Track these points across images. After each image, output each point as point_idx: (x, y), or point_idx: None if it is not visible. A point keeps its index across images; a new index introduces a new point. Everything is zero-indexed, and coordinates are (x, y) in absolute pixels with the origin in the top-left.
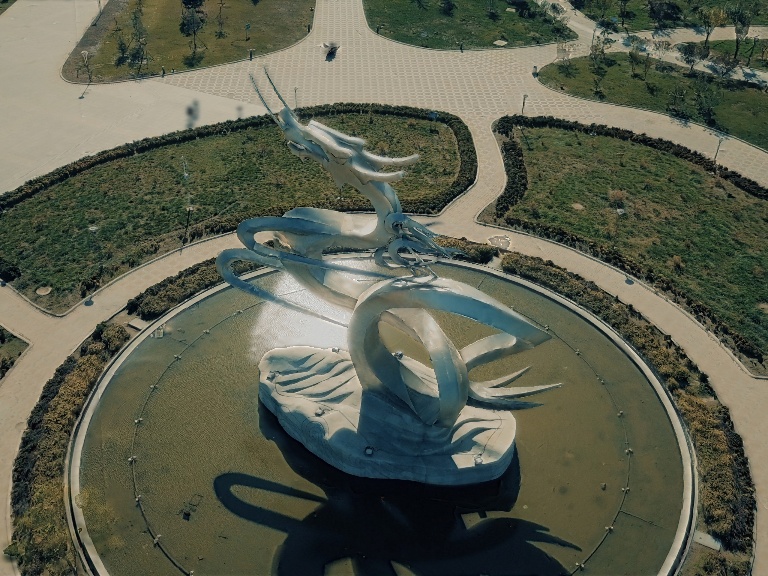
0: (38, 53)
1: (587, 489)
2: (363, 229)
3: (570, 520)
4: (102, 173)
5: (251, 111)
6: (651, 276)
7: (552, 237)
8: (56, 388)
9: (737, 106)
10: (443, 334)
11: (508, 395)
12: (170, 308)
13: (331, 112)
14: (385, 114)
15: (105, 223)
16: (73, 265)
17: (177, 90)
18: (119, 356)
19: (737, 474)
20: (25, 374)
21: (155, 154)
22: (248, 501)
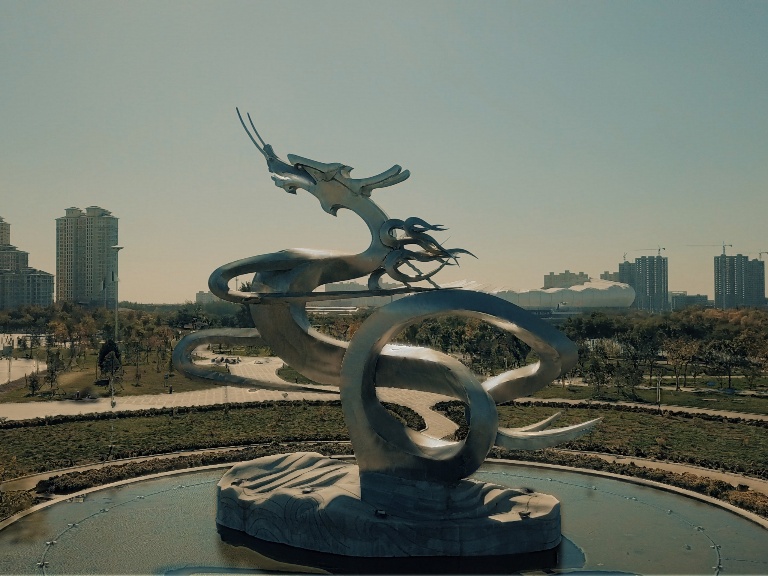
0: None
1: (668, 551)
2: (354, 254)
3: (663, 568)
4: (7, 433)
5: None
6: (641, 452)
7: None
8: None
9: None
10: None
11: (542, 435)
12: (92, 487)
13: (261, 406)
14: (318, 406)
15: (8, 454)
16: None
17: (93, 403)
18: (24, 510)
19: None
20: None
21: (70, 425)
22: None
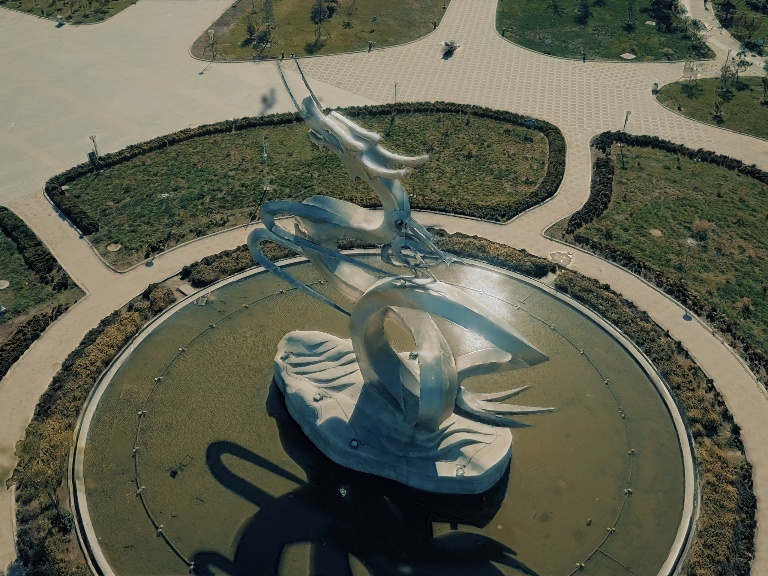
0: (176, 29)
1: (570, 521)
2: (372, 224)
3: (542, 549)
4: (198, 145)
5: (353, 101)
6: (712, 315)
7: (618, 260)
8: (96, 337)
9: None
10: (440, 339)
11: (499, 411)
12: (219, 279)
13: (430, 110)
14: (484, 117)
15: (186, 192)
16: (146, 227)
17: (290, 74)
18: (160, 317)
19: (739, 536)
20: (75, 320)
21: (251, 133)
22: (233, 470)
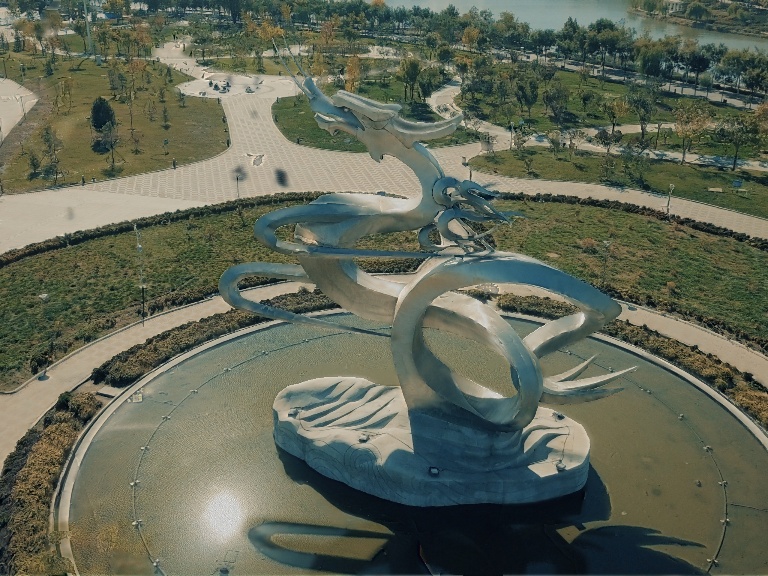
0: None
1: (681, 488)
2: (404, 207)
3: (679, 519)
4: (33, 264)
5: (188, 205)
6: (652, 301)
7: None
8: (21, 460)
9: (663, 174)
10: None
11: (581, 386)
12: (144, 373)
13: (273, 201)
14: None
15: (46, 306)
16: (16, 346)
17: (102, 194)
18: (94, 423)
19: None
20: None
21: (91, 244)
22: (297, 549)
